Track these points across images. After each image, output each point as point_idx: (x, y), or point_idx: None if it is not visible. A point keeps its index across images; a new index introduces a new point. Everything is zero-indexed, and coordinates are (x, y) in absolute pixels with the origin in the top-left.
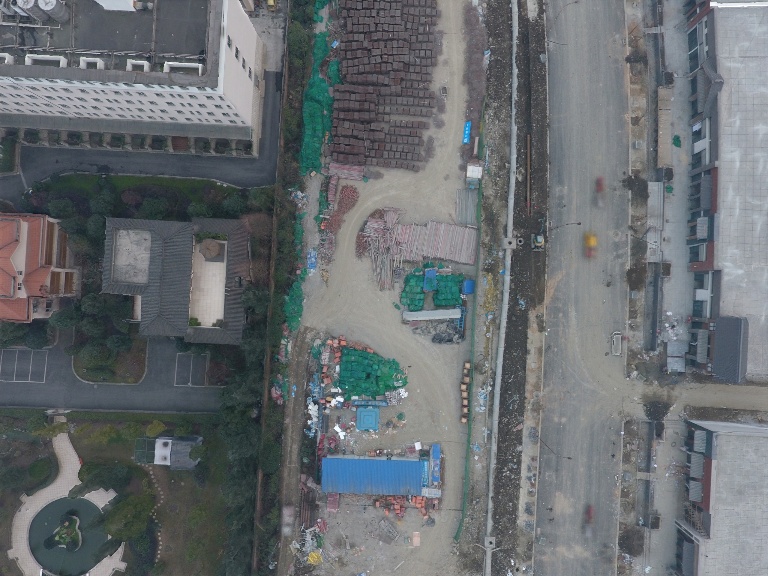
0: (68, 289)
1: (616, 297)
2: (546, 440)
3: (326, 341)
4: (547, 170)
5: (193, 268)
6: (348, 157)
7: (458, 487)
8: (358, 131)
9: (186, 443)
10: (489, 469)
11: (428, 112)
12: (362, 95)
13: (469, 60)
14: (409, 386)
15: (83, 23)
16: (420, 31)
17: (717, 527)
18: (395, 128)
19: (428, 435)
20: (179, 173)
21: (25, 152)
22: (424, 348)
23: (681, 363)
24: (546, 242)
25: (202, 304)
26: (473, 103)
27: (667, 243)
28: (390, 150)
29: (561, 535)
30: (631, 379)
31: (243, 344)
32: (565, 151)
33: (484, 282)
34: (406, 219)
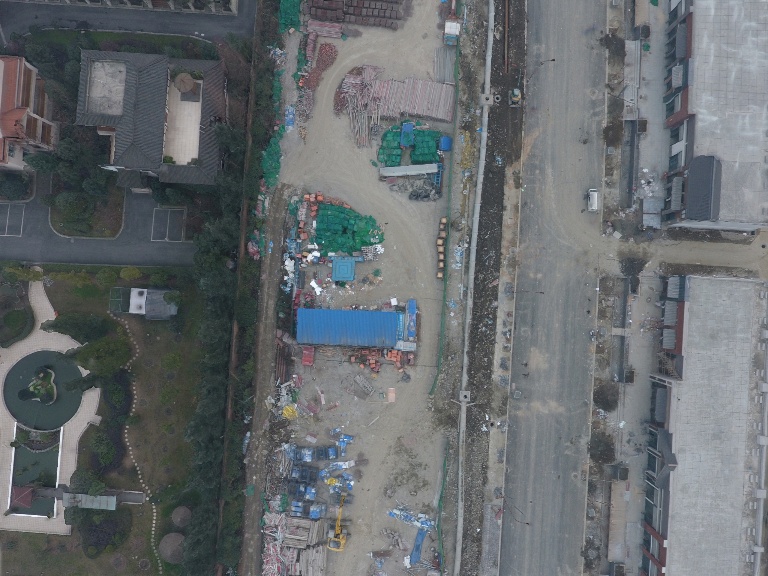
0: (45, 140)
1: (593, 154)
2: (522, 296)
3: (303, 198)
4: (525, 28)
5: (168, 106)
6: (326, 12)
7: (434, 343)
8: None
9: (161, 292)
10: (465, 325)
11: None
12: None
13: None
14: (386, 243)
15: None
16: None
17: (690, 371)
18: None
19: (404, 292)
20: (158, 30)
21: (4, 7)
22: (401, 205)
23: (657, 220)
24: (523, 99)
25: (177, 143)
26: None
27: (644, 101)
28: (369, 7)
29: (536, 390)
30: (607, 236)
31: (217, 178)
32: (543, 10)
33: (461, 140)
34: (384, 77)
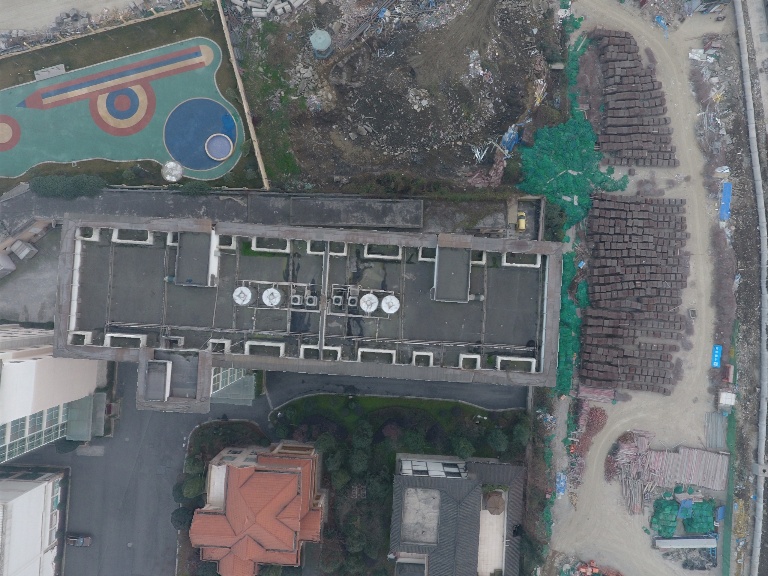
0: None
1: None
2: None
3: (575, 566)
4: None
5: None
6: (601, 383)
7: None
8: (612, 358)
9: None
10: None
11: (679, 337)
12: (616, 322)
13: (718, 283)
14: None
15: (410, 312)
16: (670, 254)
17: None
18: (646, 352)
19: None
20: (426, 394)
21: (271, 372)
22: (674, 573)
23: None
24: None
25: (479, 553)
26: (725, 328)
27: None
28: (641, 374)
29: None
30: None
31: None
32: None
33: (734, 507)
34: (655, 442)
